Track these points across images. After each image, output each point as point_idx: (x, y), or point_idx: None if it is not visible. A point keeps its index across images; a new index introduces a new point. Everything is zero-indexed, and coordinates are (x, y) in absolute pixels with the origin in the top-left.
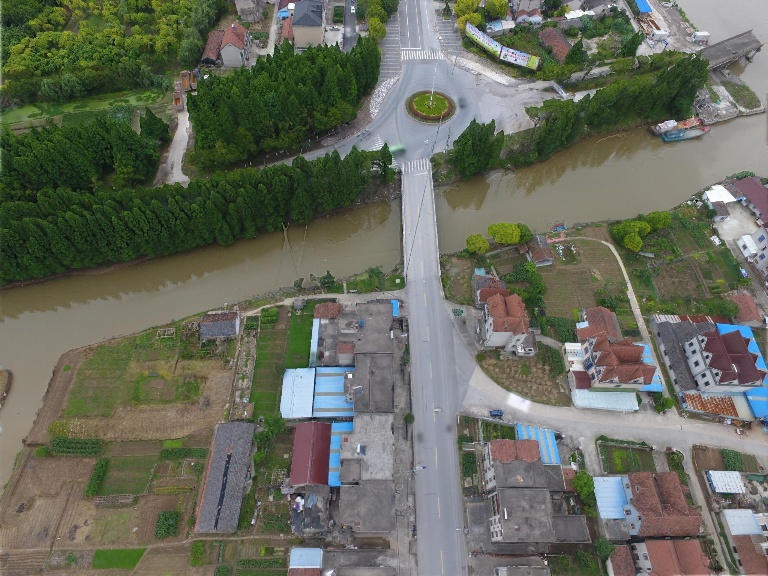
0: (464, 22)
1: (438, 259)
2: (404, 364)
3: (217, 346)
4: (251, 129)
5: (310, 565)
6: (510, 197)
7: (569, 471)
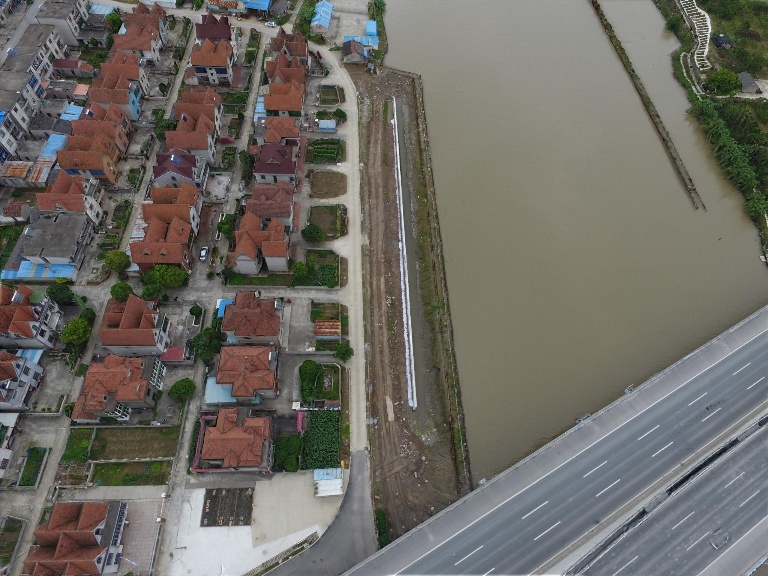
0: None
1: None
2: None
3: None
4: None
5: None
6: None
7: None
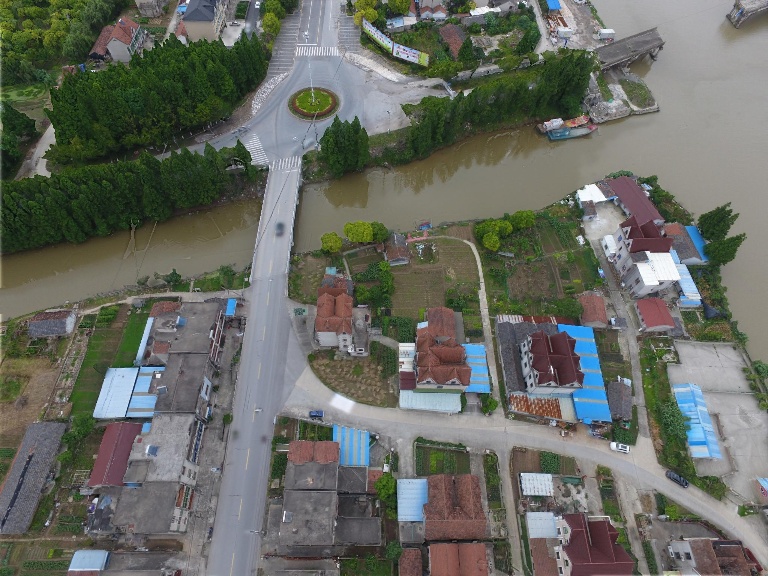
0: (360, 18)
1: (287, 258)
2: (234, 364)
3: (48, 345)
4: (112, 125)
5: (90, 567)
6: (398, 195)
7: (377, 473)
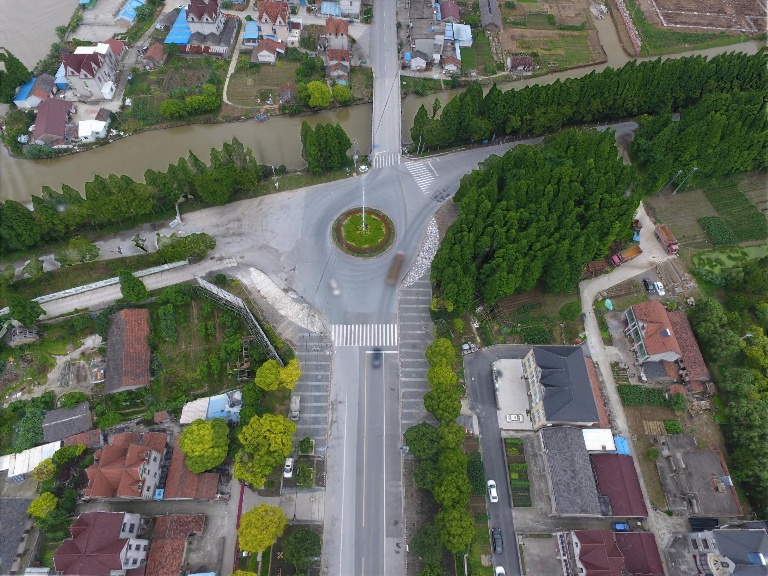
0: (290, 366)
1: None
2: None
3: None
4: None
5: None
6: None
7: (318, 2)
